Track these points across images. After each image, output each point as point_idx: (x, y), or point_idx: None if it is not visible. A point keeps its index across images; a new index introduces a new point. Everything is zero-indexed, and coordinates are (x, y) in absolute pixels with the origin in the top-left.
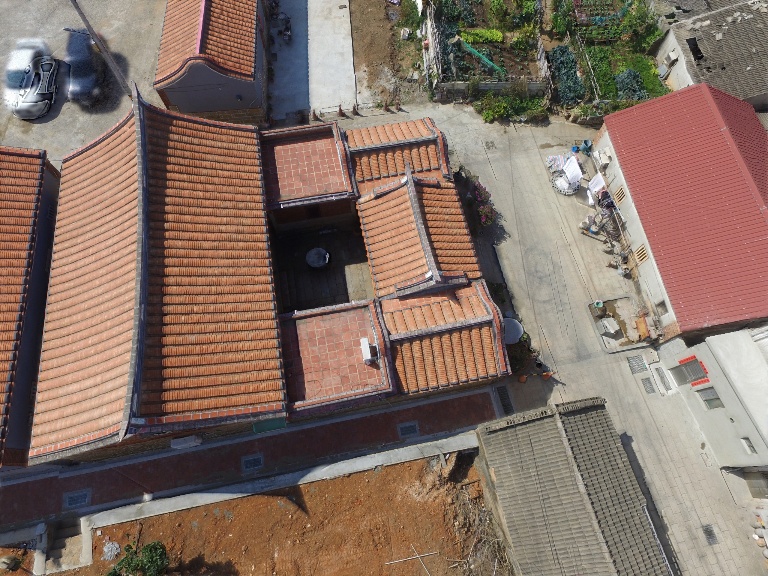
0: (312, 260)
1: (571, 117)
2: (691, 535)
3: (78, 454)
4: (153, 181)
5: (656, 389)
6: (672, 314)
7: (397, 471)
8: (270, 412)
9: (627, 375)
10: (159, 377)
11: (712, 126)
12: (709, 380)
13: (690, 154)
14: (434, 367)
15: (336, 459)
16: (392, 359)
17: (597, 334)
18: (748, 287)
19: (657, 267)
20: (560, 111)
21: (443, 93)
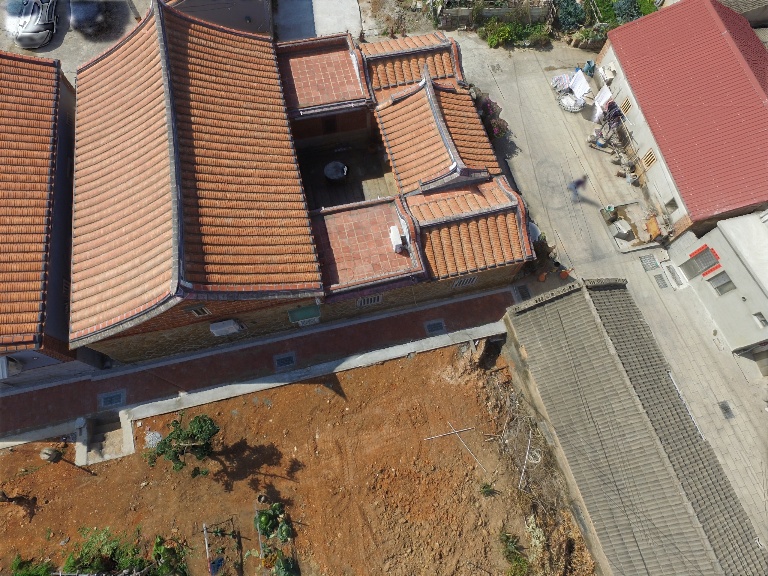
0: (330, 173)
1: (573, 41)
2: (708, 411)
3: (116, 344)
4: (176, 78)
5: (668, 284)
6: (682, 208)
7: (429, 357)
8: (309, 290)
9: (640, 272)
10: (200, 252)
11: (713, 31)
12: (720, 265)
13: (693, 59)
14: (462, 253)
15: None
16: (422, 246)
17: (610, 236)
18: (755, 174)
19: (666, 165)
20: (562, 37)
21: (448, 19)
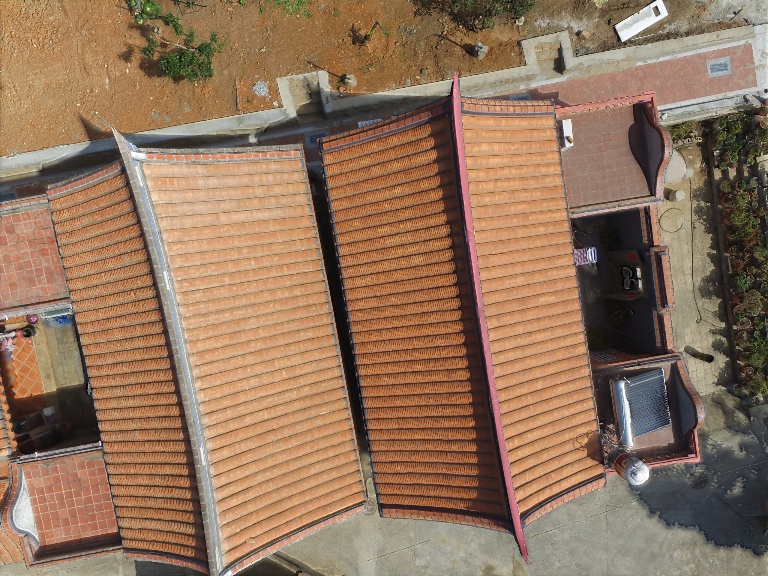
0: None
1: None
2: None
3: None
4: None
5: None
6: None
7: None
8: None
9: None
10: (138, 211)
11: None
12: None
13: None
14: None
15: (78, 171)
16: None
17: None
18: None
19: None
20: None
21: None
